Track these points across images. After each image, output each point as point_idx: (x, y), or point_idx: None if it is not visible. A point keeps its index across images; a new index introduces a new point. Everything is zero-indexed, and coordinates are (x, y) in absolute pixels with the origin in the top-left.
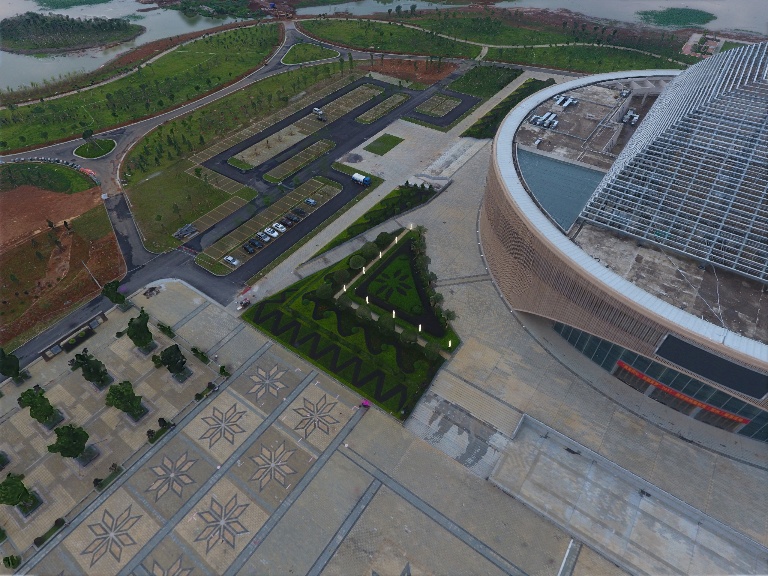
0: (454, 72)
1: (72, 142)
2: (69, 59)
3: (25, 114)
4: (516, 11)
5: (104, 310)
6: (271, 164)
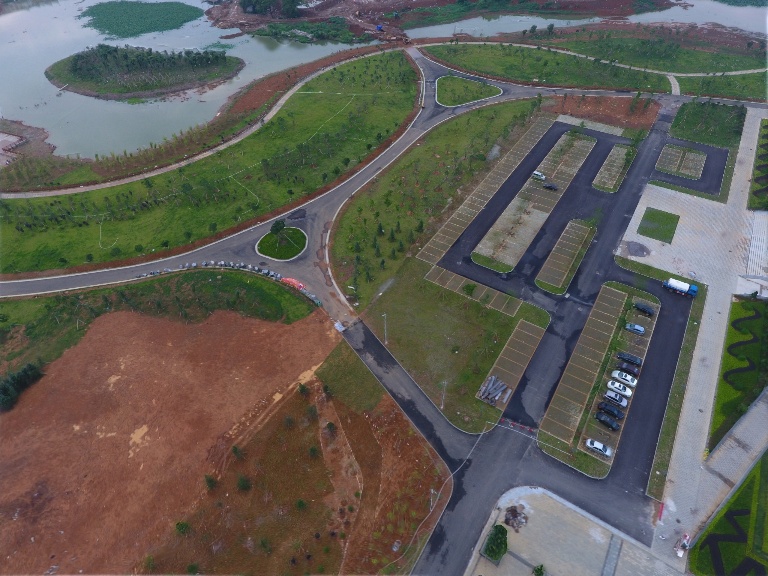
0: (661, 112)
1: (245, 233)
2: (171, 105)
3: (161, 190)
4: (677, 29)
5: (461, 560)
6: (533, 262)
